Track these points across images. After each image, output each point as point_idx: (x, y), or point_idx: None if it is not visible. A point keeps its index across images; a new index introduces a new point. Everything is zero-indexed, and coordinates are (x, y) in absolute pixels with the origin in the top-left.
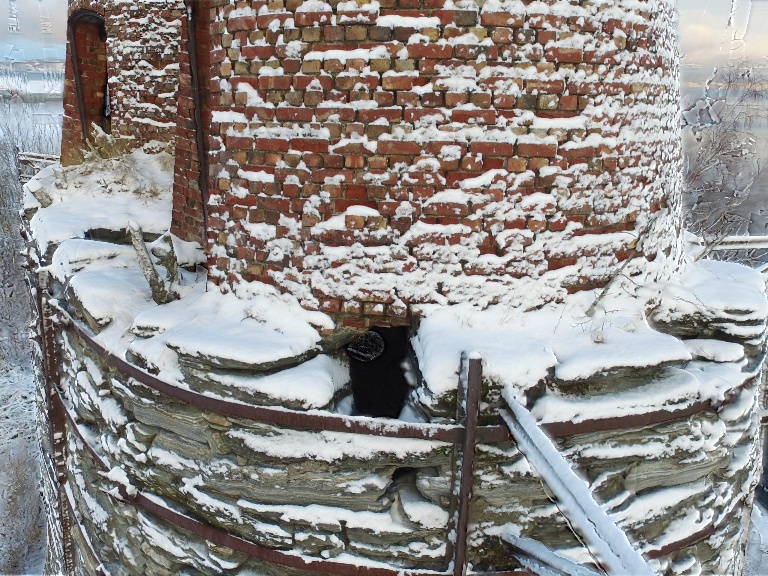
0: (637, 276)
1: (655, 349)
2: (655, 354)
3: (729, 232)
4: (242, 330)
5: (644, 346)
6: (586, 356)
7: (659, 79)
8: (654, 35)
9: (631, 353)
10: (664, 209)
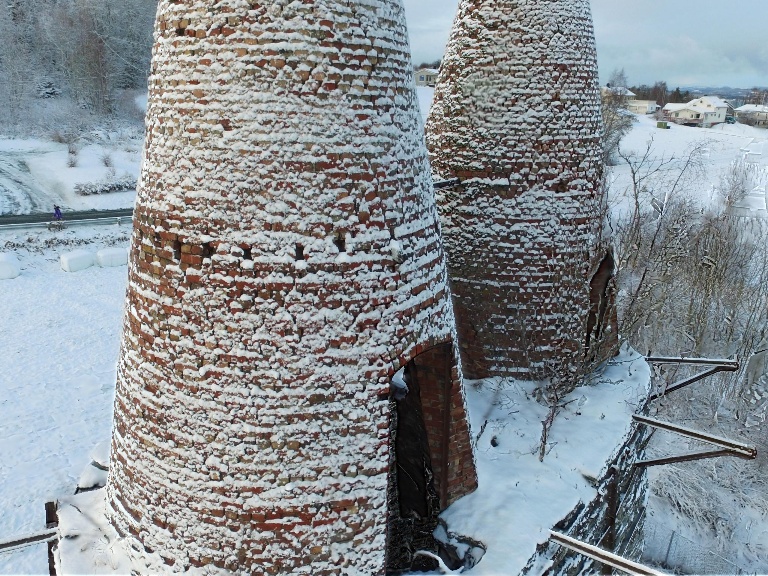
0: (134, 549)
1: (72, 572)
2: (67, 572)
3: None
4: None
5: (76, 567)
6: (67, 544)
7: (170, 447)
8: (166, 419)
9: (67, 561)
10: (169, 531)
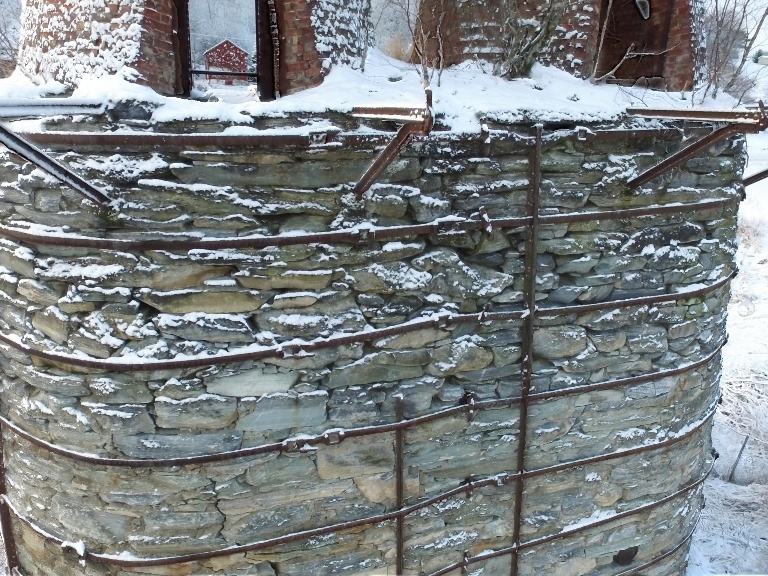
0: None
1: None
2: None
3: (8, 53)
4: None
5: None
6: None
7: None
8: None
9: None
10: None
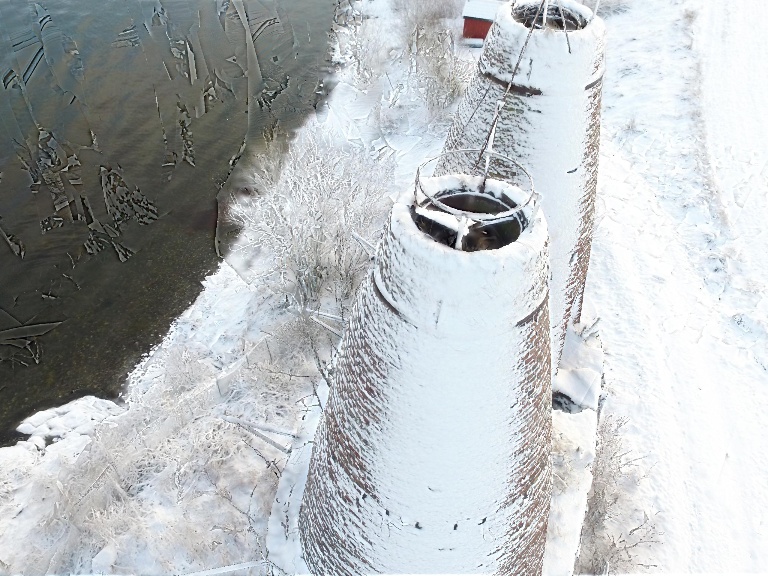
0: None
1: None
2: None
3: None
4: (583, 305)
5: None
6: None
7: None
8: None
9: None
10: None
